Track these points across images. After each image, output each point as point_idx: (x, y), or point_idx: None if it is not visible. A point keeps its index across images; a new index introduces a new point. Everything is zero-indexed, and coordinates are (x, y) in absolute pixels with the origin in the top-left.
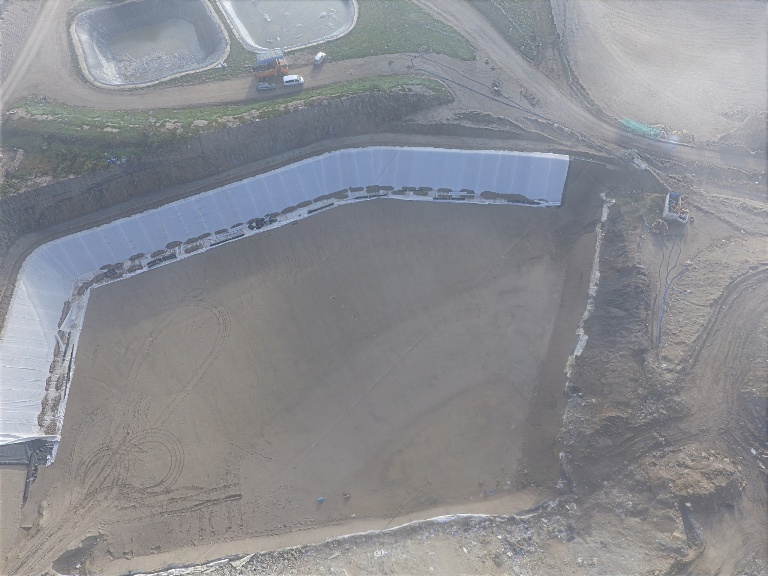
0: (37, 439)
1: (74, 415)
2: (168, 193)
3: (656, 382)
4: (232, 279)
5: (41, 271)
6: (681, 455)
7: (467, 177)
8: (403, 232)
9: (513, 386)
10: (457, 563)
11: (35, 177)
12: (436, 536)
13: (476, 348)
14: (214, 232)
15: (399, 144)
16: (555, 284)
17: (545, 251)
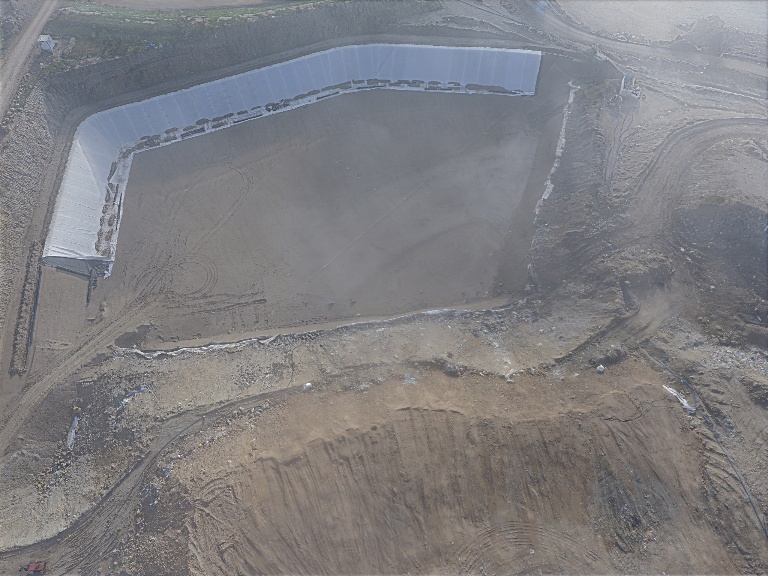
0: (95, 259)
1: (125, 243)
2: (198, 77)
3: (606, 205)
4: (253, 147)
5: (92, 135)
6: (624, 252)
7: (454, 71)
8: (399, 114)
9: (491, 226)
10: (443, 332)
11: (86, 57)
12: (426, 322)
13: (460, 199)
14: (237, 113)
15: (395, 42)
16: (528, 153)
17: (520, 129)
